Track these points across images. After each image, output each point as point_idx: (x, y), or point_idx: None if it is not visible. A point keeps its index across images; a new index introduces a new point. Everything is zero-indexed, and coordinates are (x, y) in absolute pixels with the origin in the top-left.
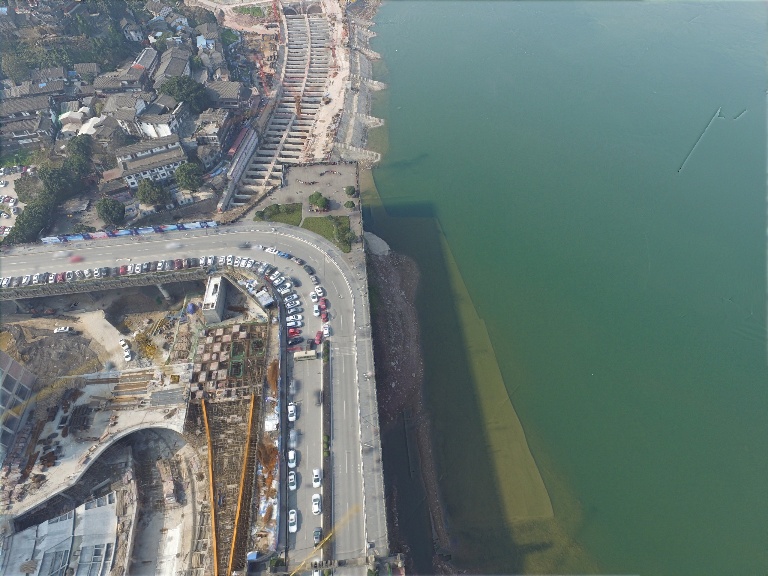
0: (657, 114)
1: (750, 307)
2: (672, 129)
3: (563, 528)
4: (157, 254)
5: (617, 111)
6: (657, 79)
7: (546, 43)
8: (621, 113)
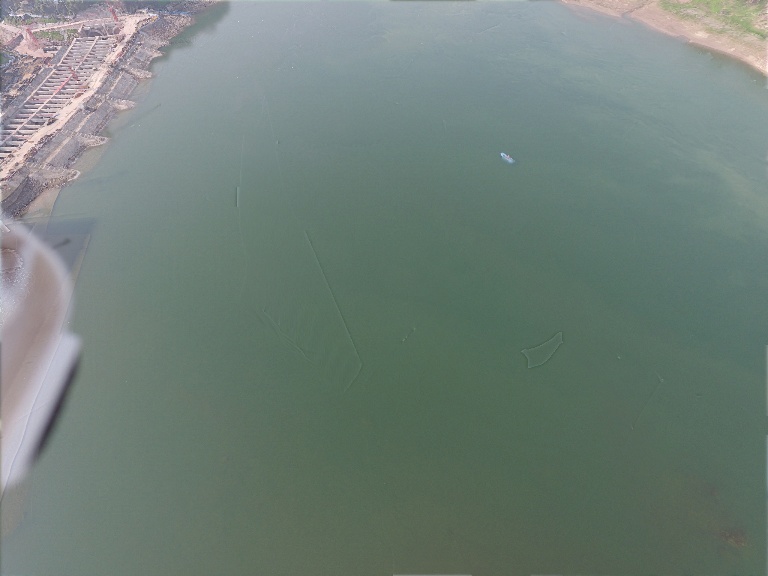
0: (383, 125)
1: (278, 318)
2: (385, 140)
3: None
4: None
5: (343, 123)
6: (407, 90)
7: (318, 57)
8: (346, 125)
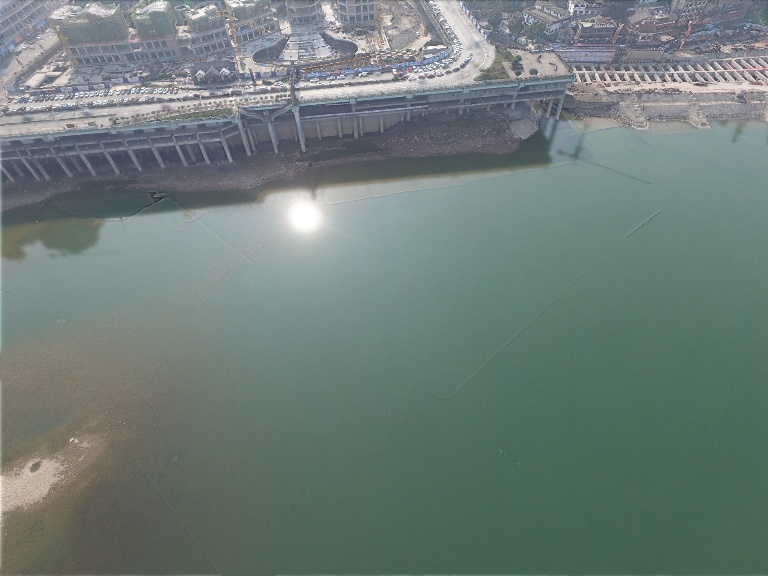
0: None
1: (486, 309)
2: None
3: (320, 207)
4: (459, 30)
5: None
6: None
7: None
8: None
